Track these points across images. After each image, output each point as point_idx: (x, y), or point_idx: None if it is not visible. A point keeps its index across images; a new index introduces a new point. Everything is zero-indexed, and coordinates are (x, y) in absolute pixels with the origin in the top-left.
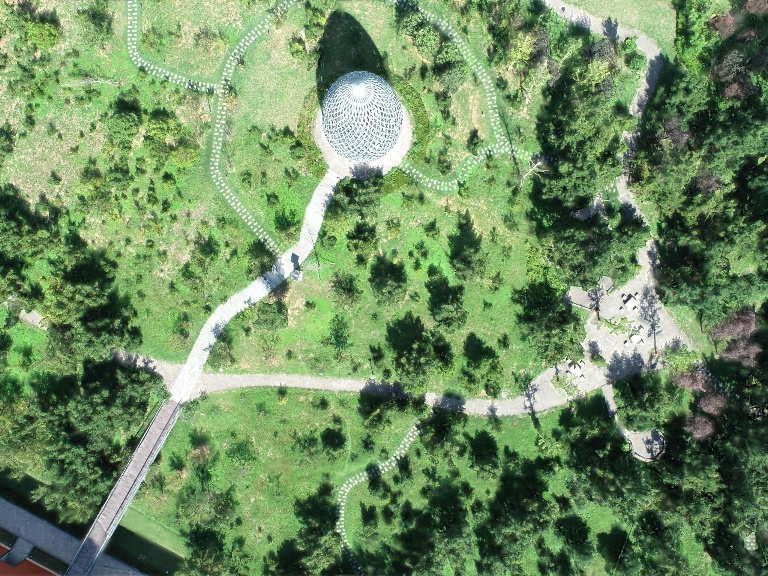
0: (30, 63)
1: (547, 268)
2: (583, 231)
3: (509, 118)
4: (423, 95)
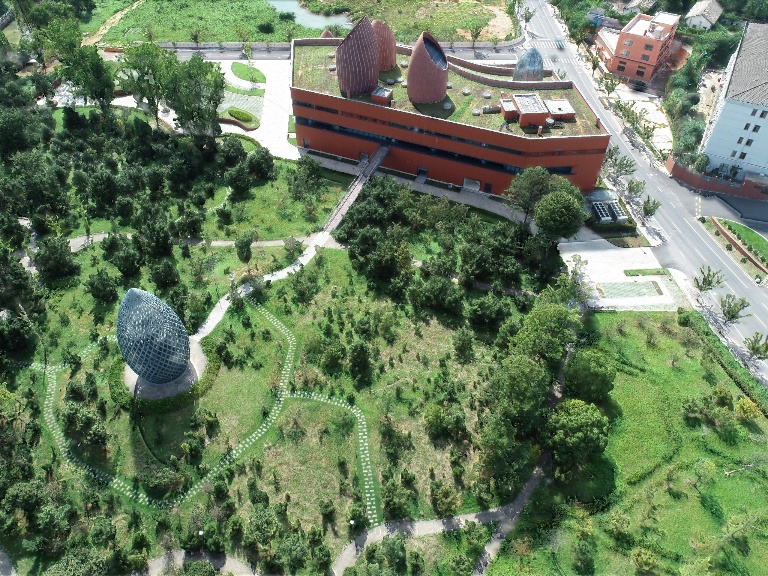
0: (445, 398)
1: (47, 298)
2: (7, 293)
3: (39, 390)
4: (108, 398)
